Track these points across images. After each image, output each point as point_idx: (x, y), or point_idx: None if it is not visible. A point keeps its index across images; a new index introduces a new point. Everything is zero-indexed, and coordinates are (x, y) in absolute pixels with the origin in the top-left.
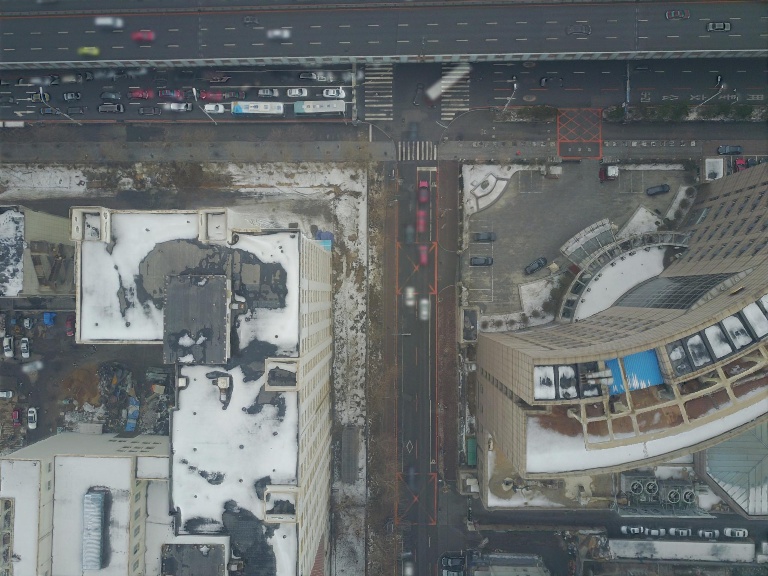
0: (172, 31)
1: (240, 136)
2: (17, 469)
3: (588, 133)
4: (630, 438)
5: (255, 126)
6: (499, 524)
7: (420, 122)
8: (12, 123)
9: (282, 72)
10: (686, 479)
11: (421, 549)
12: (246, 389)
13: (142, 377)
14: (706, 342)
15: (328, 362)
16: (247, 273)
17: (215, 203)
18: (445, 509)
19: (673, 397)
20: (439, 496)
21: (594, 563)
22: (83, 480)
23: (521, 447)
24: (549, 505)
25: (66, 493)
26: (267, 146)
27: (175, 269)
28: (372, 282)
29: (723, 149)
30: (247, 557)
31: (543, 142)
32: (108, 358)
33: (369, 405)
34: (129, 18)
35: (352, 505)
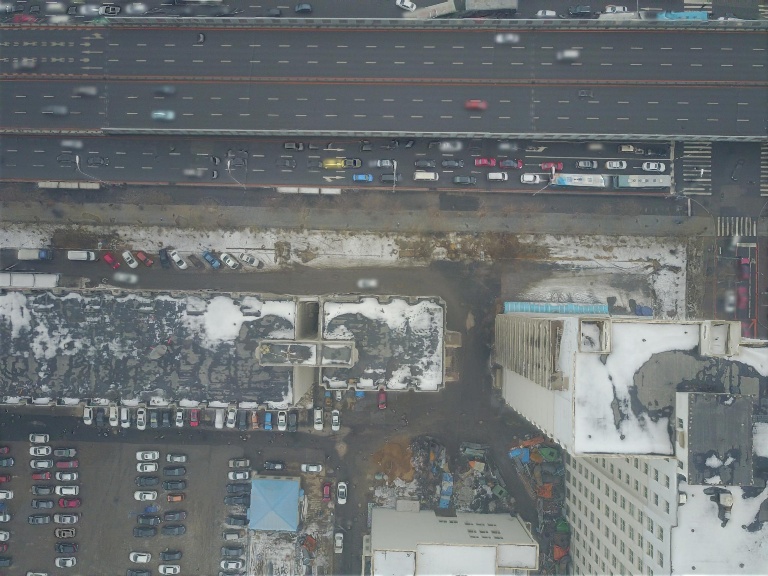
0: (504, 102)
1: (558, 208)
2: (390, 560)
3: None
4: None
5: (572, 197)
6: None
7: (739, 197)
8: (328, 190)
9: (599, 143)
10: None
11: None
12: (746, 506)
13: (455, 452)
14: None
15: None
16: (746, 386)
17: (532, 275)
18: None
19: None
20: None
21: None
22: (445, 569)
23: None
24: None
25: None
26: (584, 218)
27: (672, 381)
28: None
29: None
30: None
31: None
32: (420, 432)
33: None
34: (459, 88)
35: None
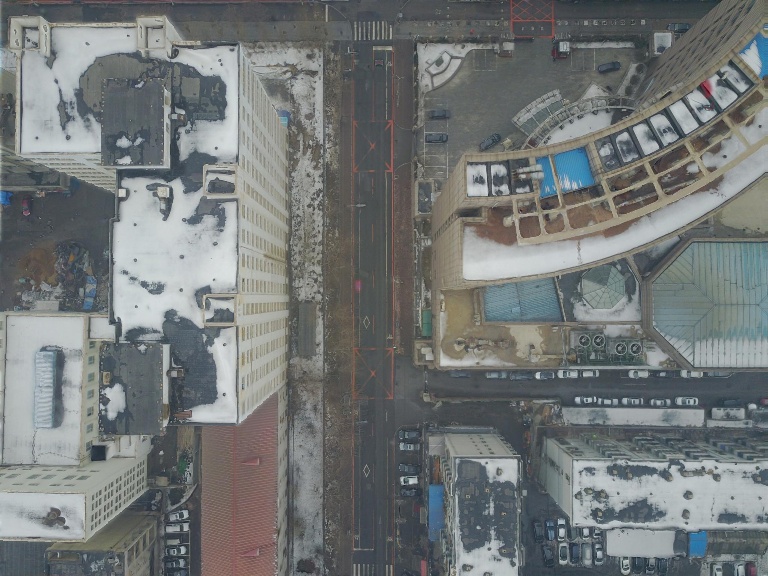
0: None
1: (197, 16)
2: None
3: (541, 13)
4: (561, 232)
5: (212, 7)
6: (455, 397)
7: (376, 2)
8: None
9: None
10: (634, 337)
11: (378, 423)
12: (186, 200)
13: (99, 256)
14: (634, 138)
15: (283, 233)
16: (187, 86)
17: None
18: (402, 383)
19: (603, 194)
20: (396, 371)
21: (547, 428)
22: (35, 340)
23: (458, 254)
24: (500, 364)
25: (18, 353)
26: None
27: None
28: (329, 160)
29: (672, 27)
30: (187, 366)
31: (497, 21)
32: (65, 237)
33: (326, 281)
34: None
35: (309, 380)
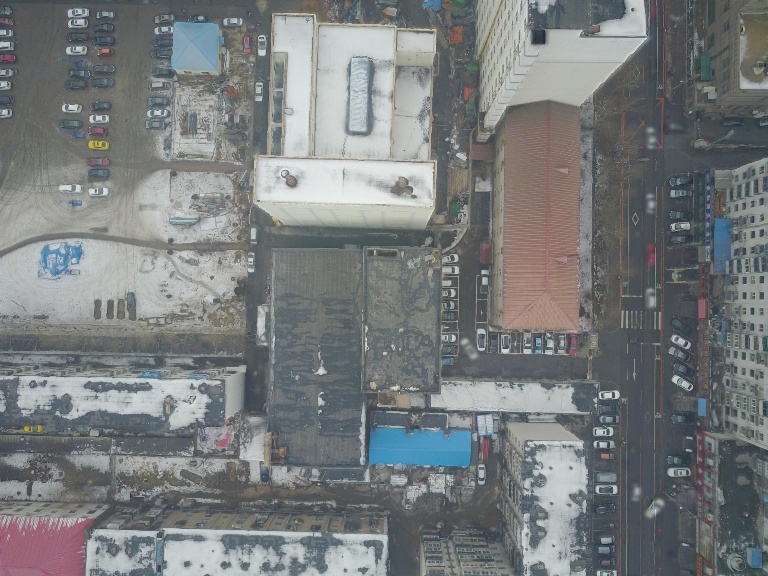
0: None
1: None
2: (289, 26)
3: None
4: None
5: None
6: None
7: None
8: None
9: None
10: None
11: (648, 172)
12: None
13: (370, 6)
14: None
15: None
16: None
17: None
18: (672, 133)
19: None
20: (666, 121)
21: None
22: (346, 50)
23: None
24: None
25: (329, 63)
26: None
27: None
28: None
29: None
30: None
31: None
32: None
33: None
34: None
35: None
